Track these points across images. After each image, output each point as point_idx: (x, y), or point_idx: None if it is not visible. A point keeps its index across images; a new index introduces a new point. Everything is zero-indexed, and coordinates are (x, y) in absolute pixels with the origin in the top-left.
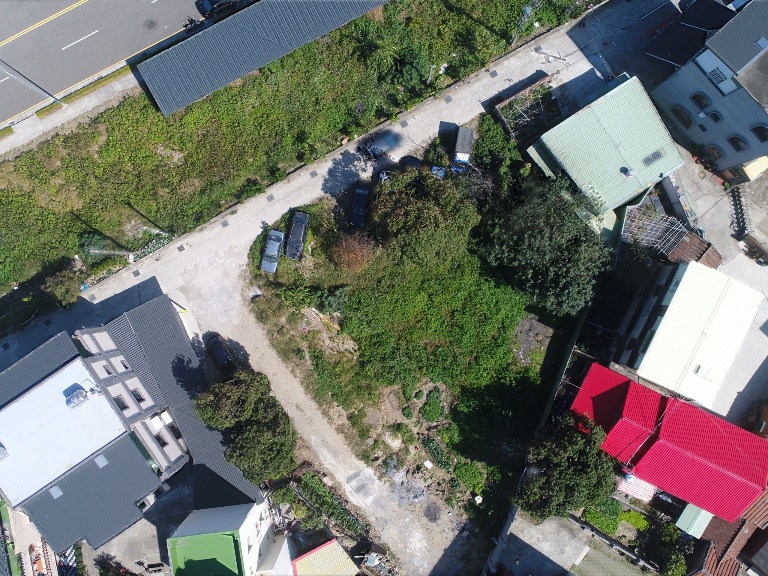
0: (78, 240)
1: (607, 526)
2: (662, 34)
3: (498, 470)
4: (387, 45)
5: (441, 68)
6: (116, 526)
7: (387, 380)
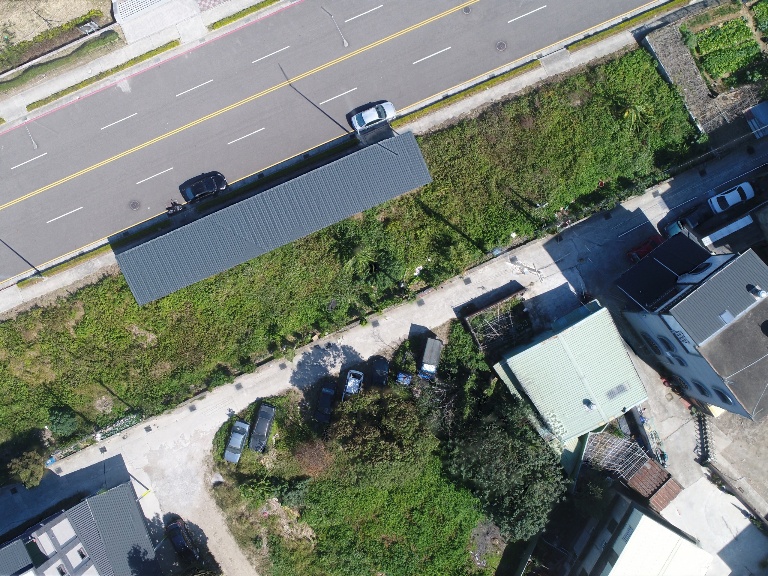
0: (48, 413)
1: None
2: (635, 268)
3: None
4: (362, 254)
5: (416, 270)
6: None
7: (342, 573)
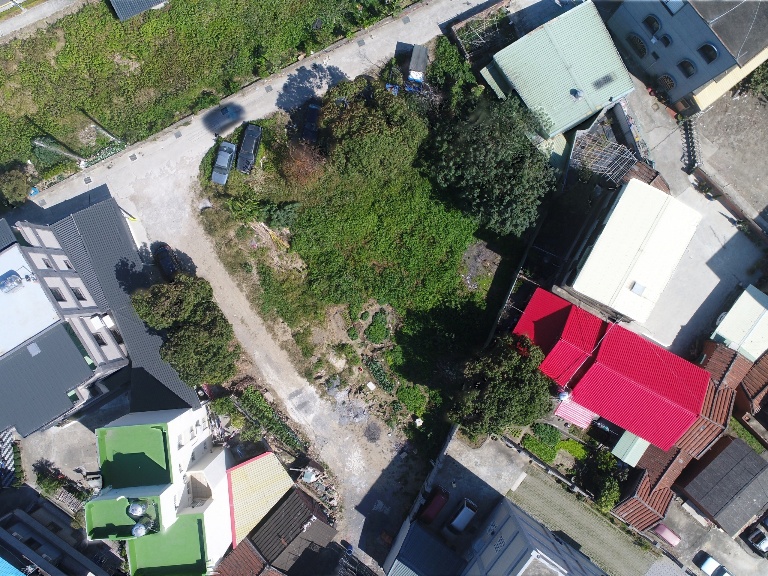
0: (31, 144)
1: (545, 453)
2: None
3: (440, 393)
4: None
5: None
6: (46, 415)
7: (333, 299)
